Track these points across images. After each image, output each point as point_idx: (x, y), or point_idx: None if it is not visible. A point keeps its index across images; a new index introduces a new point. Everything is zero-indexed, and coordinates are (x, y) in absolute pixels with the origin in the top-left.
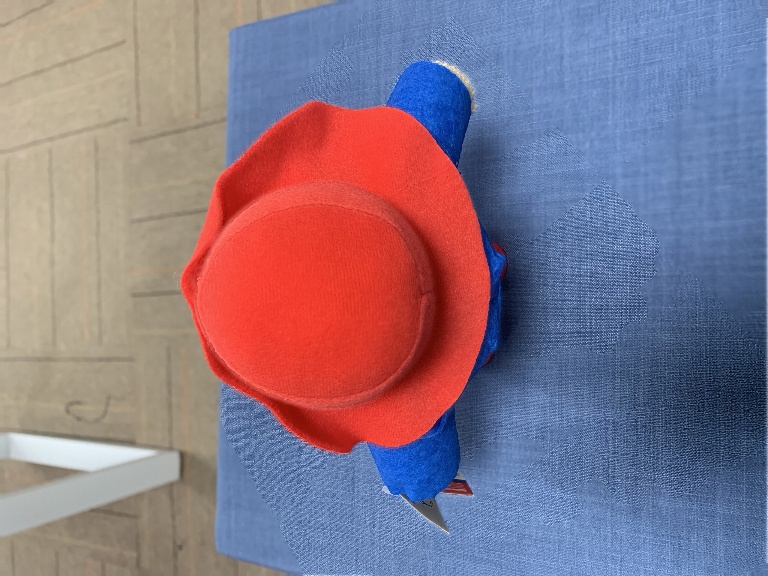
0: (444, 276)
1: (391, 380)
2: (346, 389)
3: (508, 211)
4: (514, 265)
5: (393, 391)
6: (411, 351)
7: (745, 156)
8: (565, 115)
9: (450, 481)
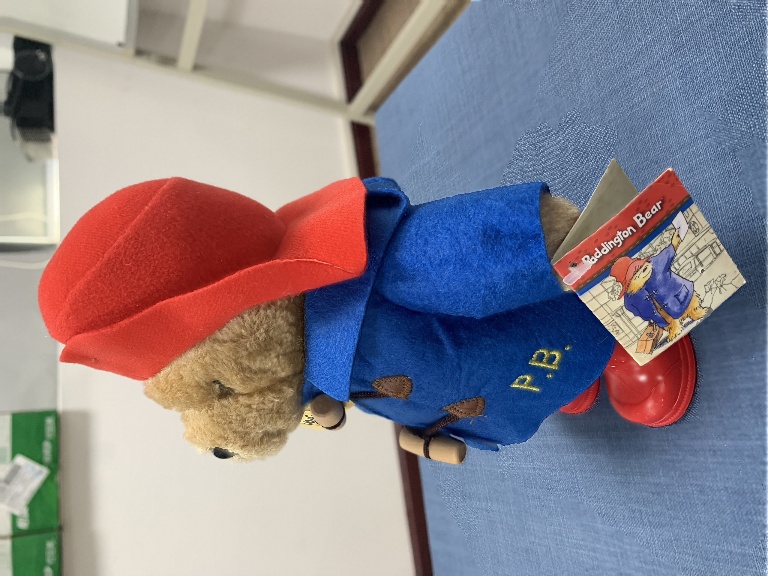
0: None
1: None
2: (131, 206)
3: None
4: None
5: None
6: None
7: (467, 105)
8: None
9: None
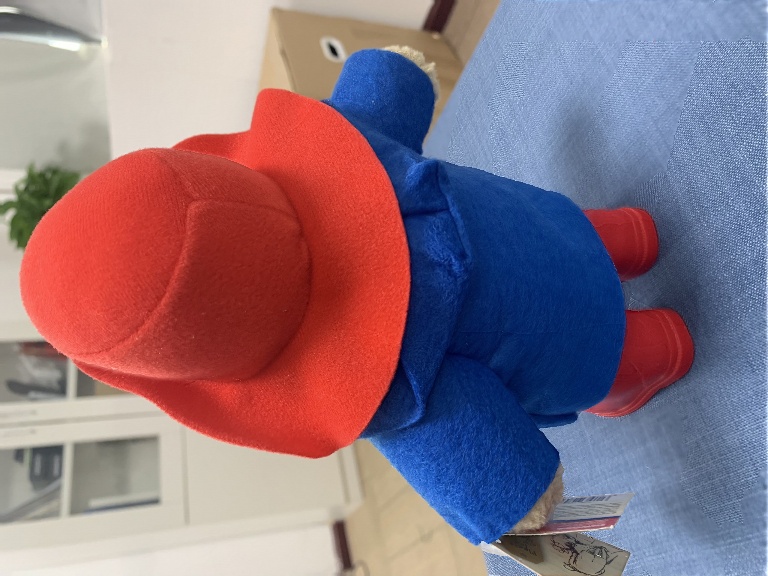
0: (315, 201)
1: (170, 298)
2: (119, 322)
3: (624, 164)
4: (660, 217)
5: (307, 355)
6: (180, 258)
7: None
8: (627, 22)
9: (530, 499)
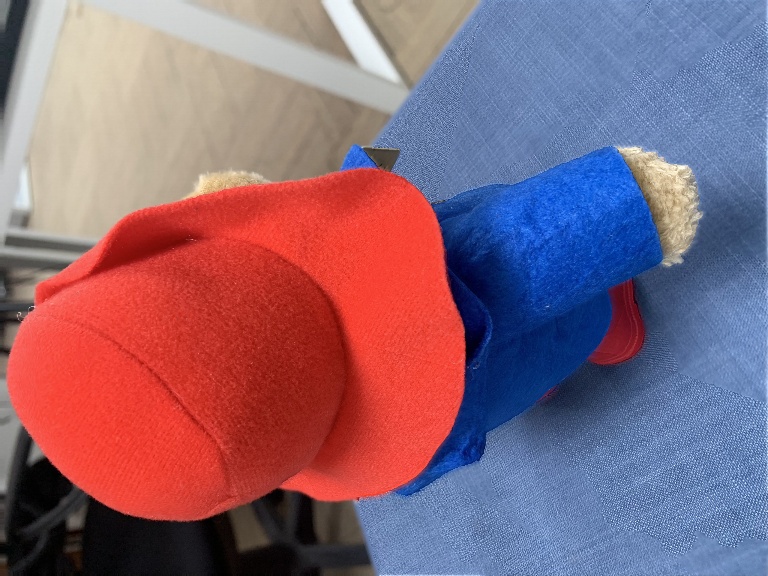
0: (352, 445)
1: None
2: None
3: (691, 318)
4: (635, 366)
5: None
6: None
7: None
8: None
9: None
